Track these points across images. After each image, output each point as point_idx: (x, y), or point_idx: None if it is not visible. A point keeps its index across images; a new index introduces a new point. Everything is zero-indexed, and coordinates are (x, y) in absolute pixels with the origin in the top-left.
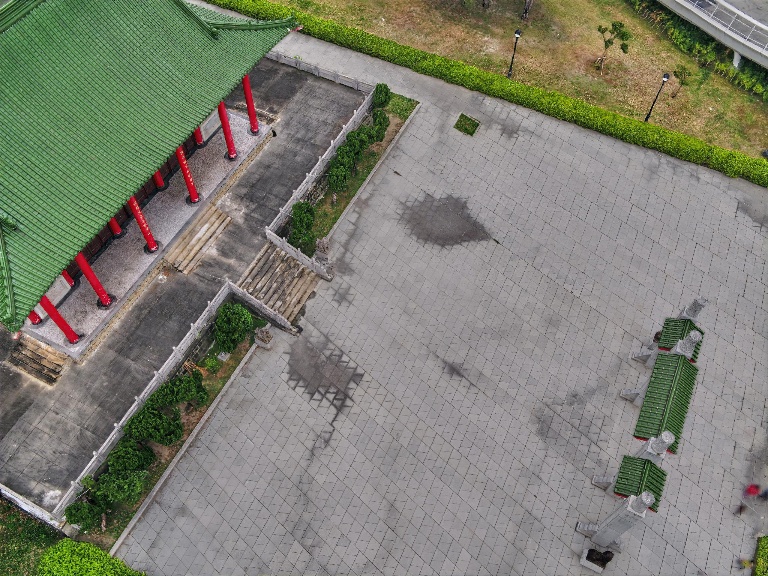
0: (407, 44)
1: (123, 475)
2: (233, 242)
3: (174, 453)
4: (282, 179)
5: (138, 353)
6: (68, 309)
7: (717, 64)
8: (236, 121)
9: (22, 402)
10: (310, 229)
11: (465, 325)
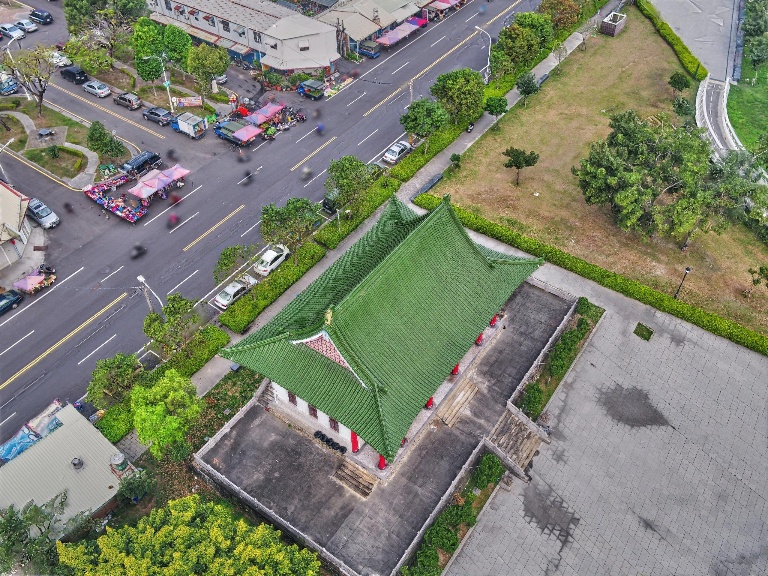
0: (592, 262)
1: (427, 570)
2: (481, 407)
3: (447, 559)
4: (512, 362)
5: (422, 482)
6: None
7: None
8: None
9: (347, 507)
10: None
11: (654, 491)
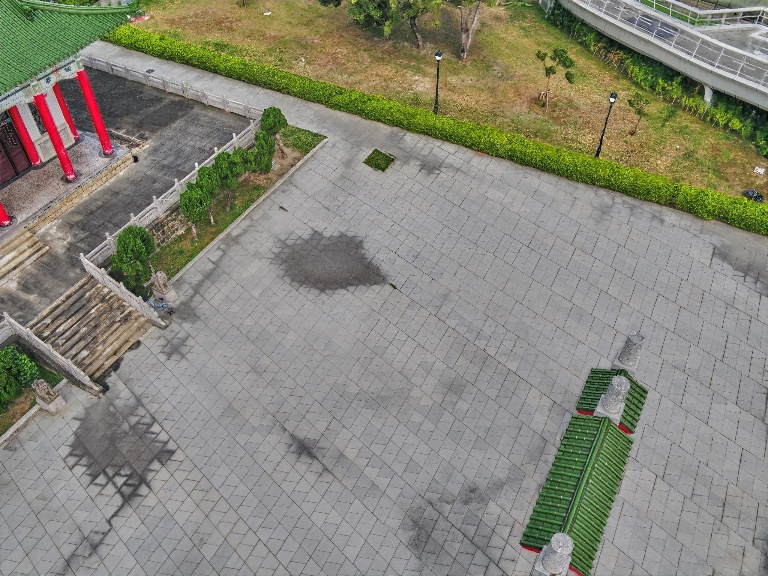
0: None
1: None
2: (42, 275)
3: None
4: (129, 206)
5: None
6: None
7: (684, 100)
8: (89, 143)
9: None
10: (145, 262)
11: (332, 388)
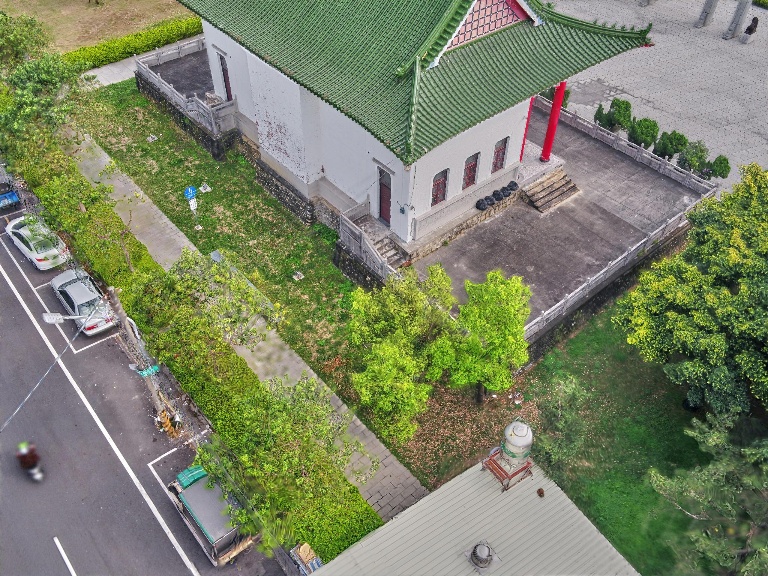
0: None
1: None
2: None
3: None
4: None
5: (560, 144)
6: None
7: None
8: None
9: (591, 208)
10: None
11: None
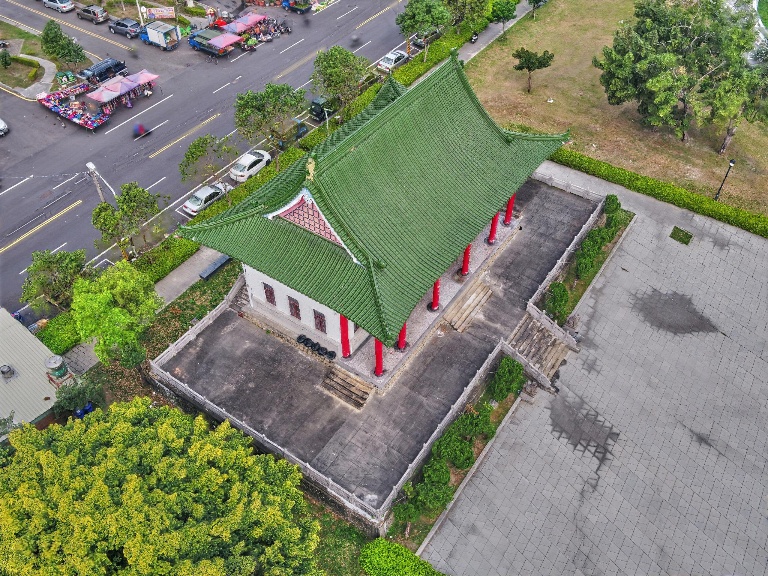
0: None
1: (436, 487)
2: (497, 310)
3: (460, 480)
4: (531, 264)
5: (428, 391)
6: (370, 349)
7: None
8: None
9: (336, 420)
10: None
11: (706, 402)
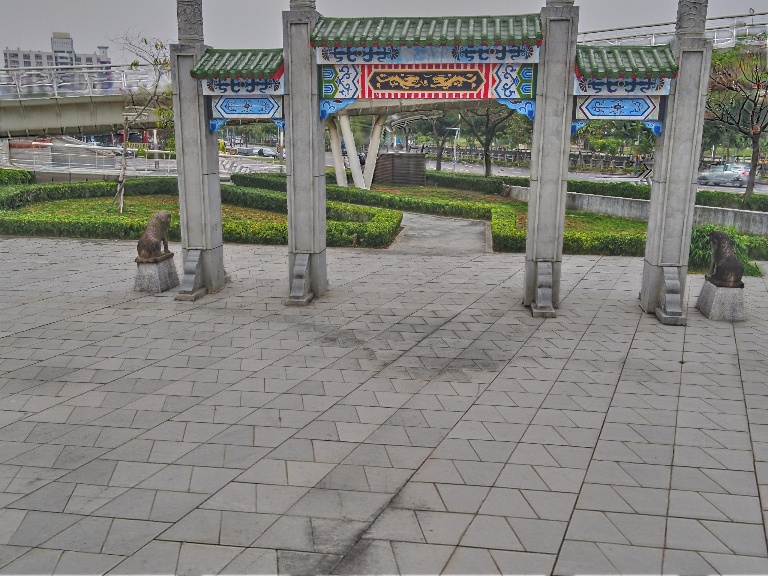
0: None
1: None
2: None
3: None
4: None
5: None
6: None
7: None
8: None
9: None
10: None
11: None
